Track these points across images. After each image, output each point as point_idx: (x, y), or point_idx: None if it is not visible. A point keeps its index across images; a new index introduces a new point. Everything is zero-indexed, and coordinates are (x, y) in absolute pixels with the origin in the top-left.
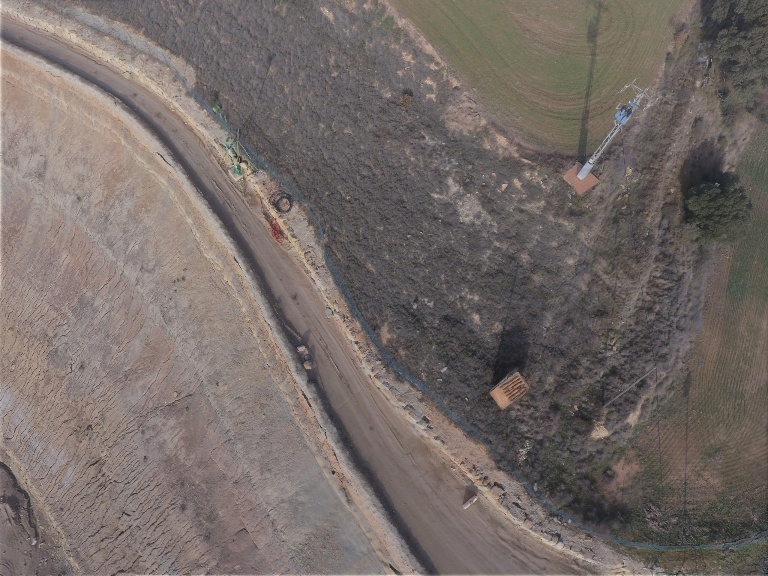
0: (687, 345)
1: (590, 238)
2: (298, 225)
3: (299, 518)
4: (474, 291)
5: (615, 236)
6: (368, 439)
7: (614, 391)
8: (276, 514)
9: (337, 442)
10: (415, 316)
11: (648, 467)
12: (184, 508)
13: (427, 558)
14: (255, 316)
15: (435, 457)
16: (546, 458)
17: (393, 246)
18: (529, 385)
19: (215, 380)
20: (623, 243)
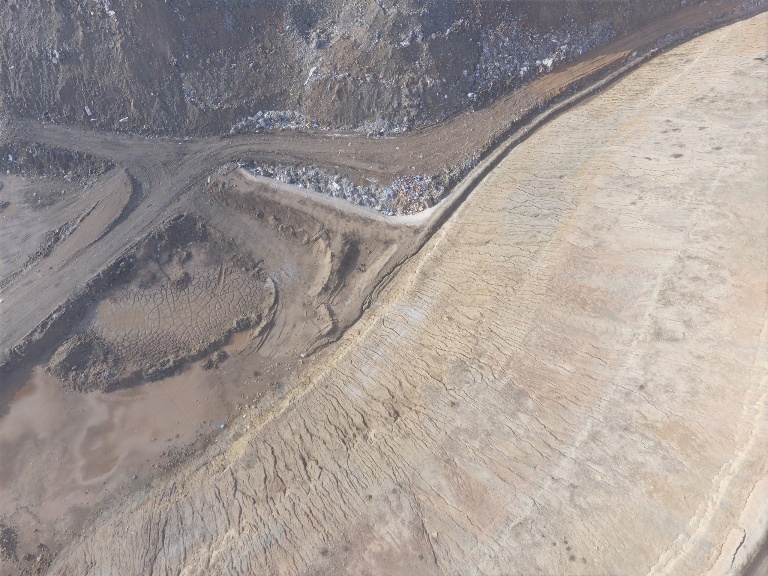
0: None
1: None
2: None
3: None
4: None
5: None
6: None
7: None
8: None
9: None
10: None
11: None
12: (324, 554)
13: None
14: None
15: None
16: None
17: None
18: None
19: None
20: None
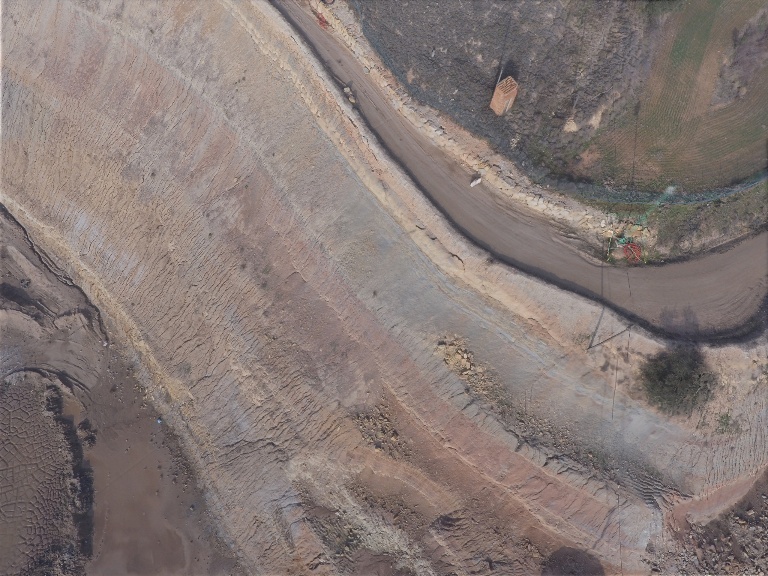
0: (638, 82)
1: (565, 0)
2: (341, 11)
3: (343, 234)
4: (478, 38)
5: (584, 1)
6: (399, 145)
7: (581, 101)
8: (324, 238)
9: (376, 144)
10: (433, 61)
11: (606, 155)
12: (244, 266)
13: (444, 211)
14: (308, 79)
15: (449, 158)
16: (531, 147)
17: (416, 15)
18: (519, 98)
19: (271, 152)
20: (590, 7)
